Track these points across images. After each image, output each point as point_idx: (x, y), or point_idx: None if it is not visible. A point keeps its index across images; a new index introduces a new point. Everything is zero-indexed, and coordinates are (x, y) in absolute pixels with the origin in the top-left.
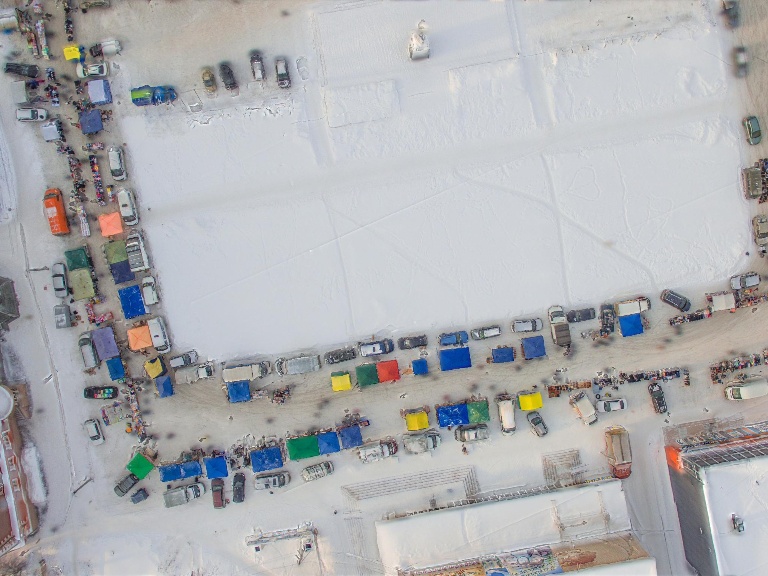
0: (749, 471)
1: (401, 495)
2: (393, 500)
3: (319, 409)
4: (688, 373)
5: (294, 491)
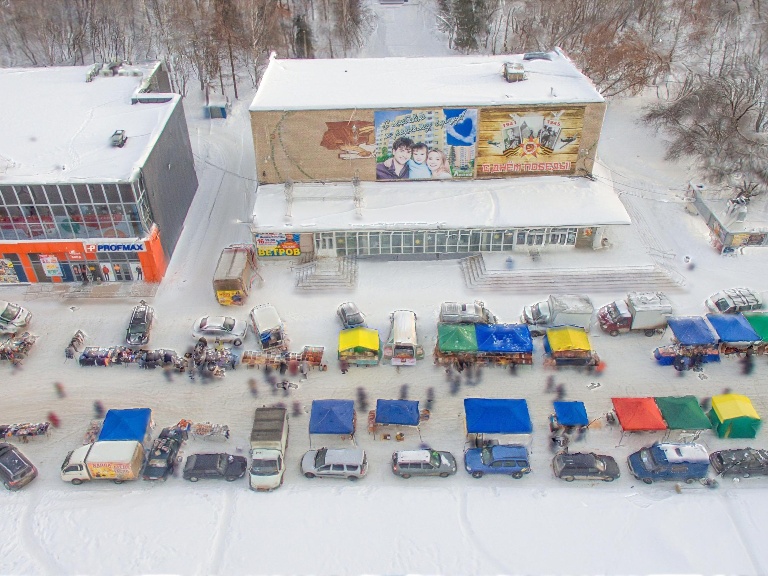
0: (67, 178)
1: (586, 264)
2: (599, 261)
3: (761, 385)
4: (70, 348)
5: (766, 289)
